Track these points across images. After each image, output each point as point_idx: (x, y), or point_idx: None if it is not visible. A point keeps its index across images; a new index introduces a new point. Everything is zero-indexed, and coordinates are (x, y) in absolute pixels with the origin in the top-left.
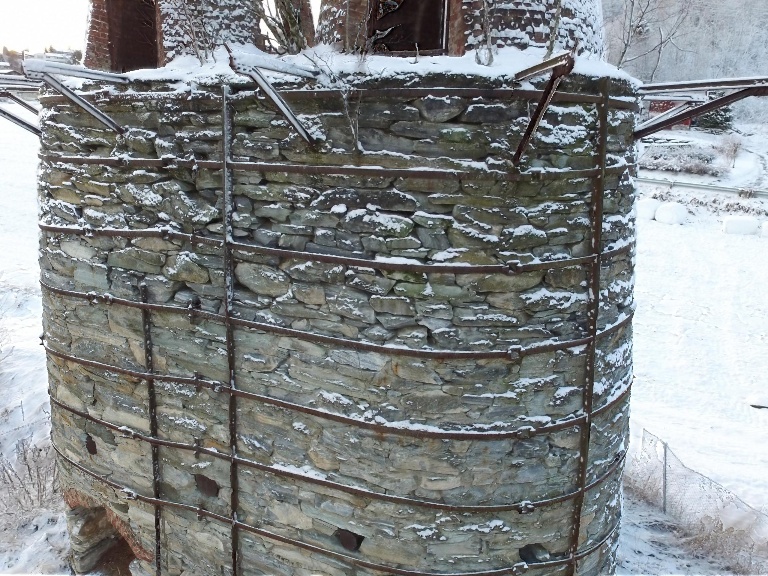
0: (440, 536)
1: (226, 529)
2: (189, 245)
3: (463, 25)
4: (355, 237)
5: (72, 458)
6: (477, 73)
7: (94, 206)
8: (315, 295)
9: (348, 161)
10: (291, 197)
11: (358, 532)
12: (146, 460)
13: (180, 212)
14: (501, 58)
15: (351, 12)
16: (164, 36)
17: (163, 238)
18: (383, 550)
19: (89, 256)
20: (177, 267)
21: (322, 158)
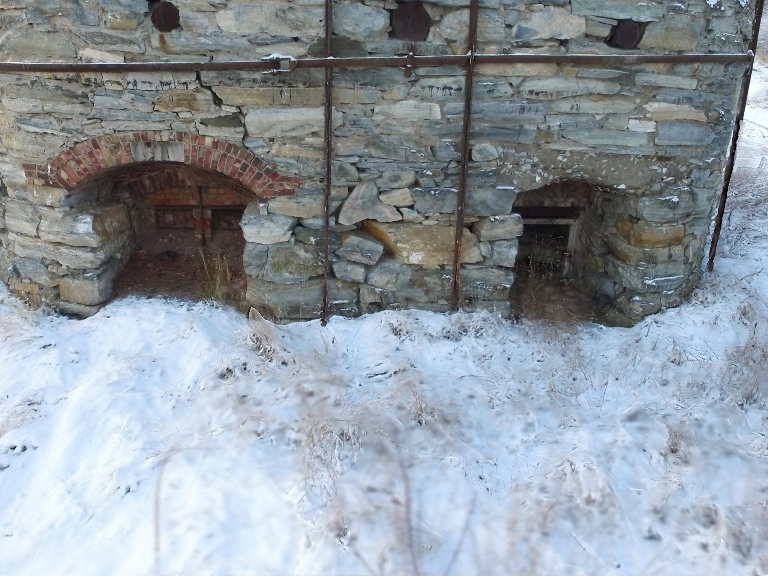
0: (721, 6)
1: (450, 79)
2: None
3: None
4: None
5: (103, 60)
6: None
7: None
8: None
9: None
10: None
11: (646, 16)
12: (298, 7)
13: None
14: None
15: None
16: None
17: None
18: (671, 33)
19: None
20: None
21: None
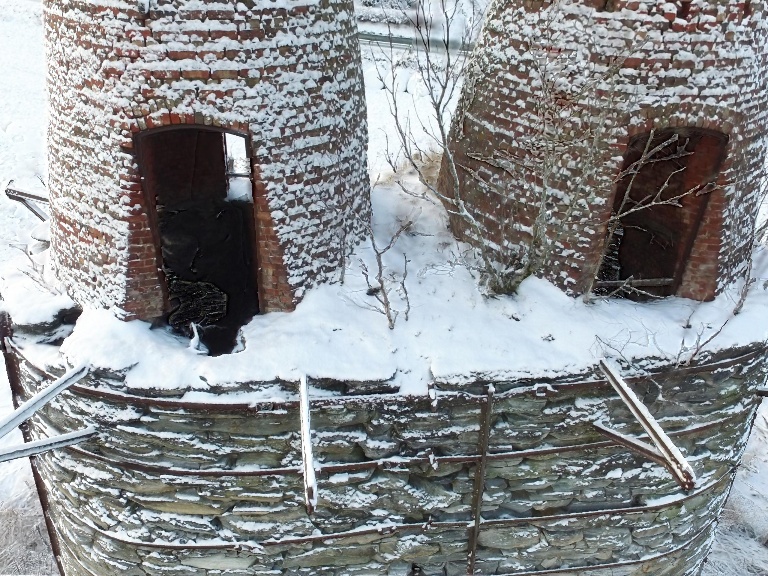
0: None
1: None
2: (413, 529)
3: (716, 273)
4: (625, 490)
5: None
6: (756, 340)
7: (251, 517)
8: (574, 539)
9: (625, 430)
10: (561, 472)
11: None
12: None
13: (406, 506)
14: (747, 302)
15: (590, 256)
16: (288, 271)
17: (382, 534)
18: None
19: (245, 566)
20: (400, 553)
21: (600, 434)
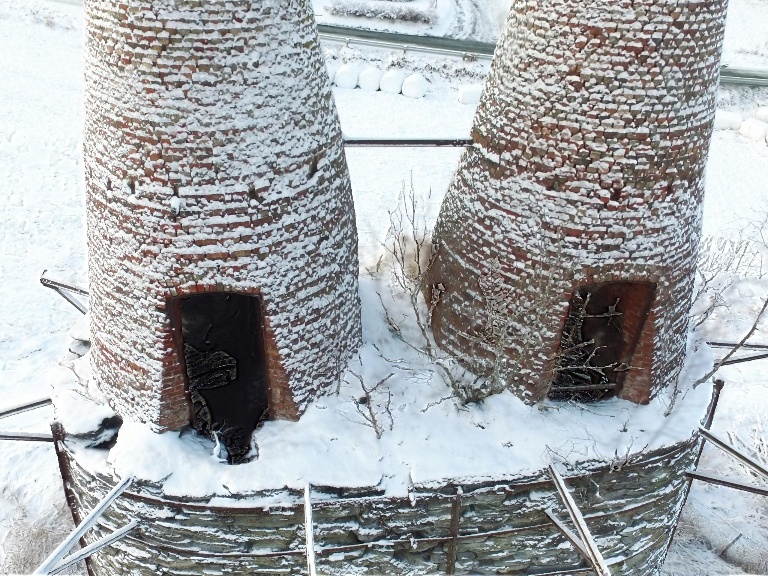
0: None
1: None
2: None
3: (649, 384)
4: (574, 556)
5: None
6: (681, 440)
7: None
8: None
9: None
10: (519, 546)
11: None
12: None
13: (392, 574)
14: (677, 404)
15: (543, 374)
16: (293, 393)
17: None
18: None
19: None
20: None
21: None
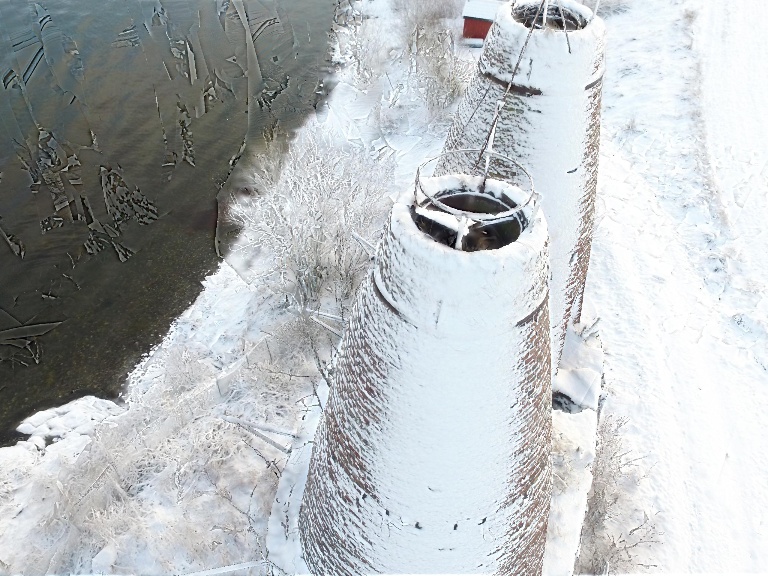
0: None
1: None
2: None
3: None
4: None
5: None
6: None
7: None
8: None
9: None
10: None
11: None
12: None
13: None
14: (288, 544)
15: None
16: None
17: None
18: None
19: None
20: None
21: None
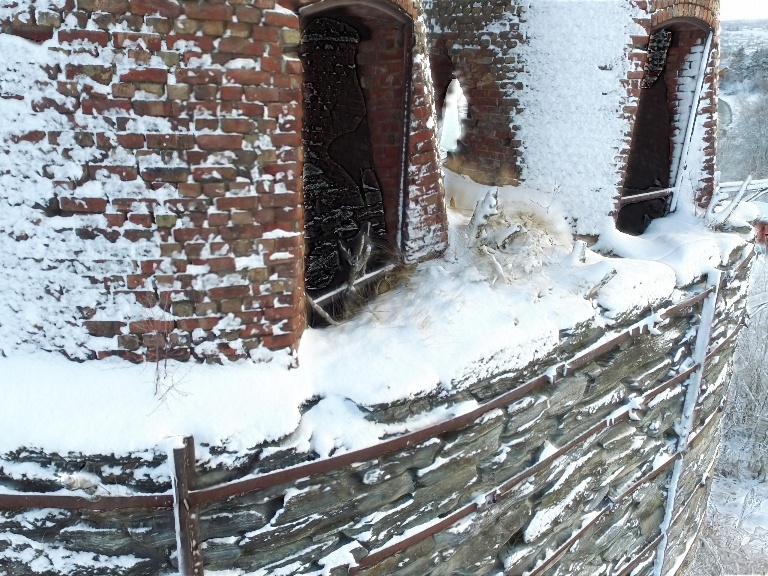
0: None
1: None
2: None
3: None
4: None
5: None
6: None
7: None
8: None
9: None
10: None
11: None
12: None
13: None
14: None
15: None
16: None
17: None
18: None
19: None
20: None
21: None
